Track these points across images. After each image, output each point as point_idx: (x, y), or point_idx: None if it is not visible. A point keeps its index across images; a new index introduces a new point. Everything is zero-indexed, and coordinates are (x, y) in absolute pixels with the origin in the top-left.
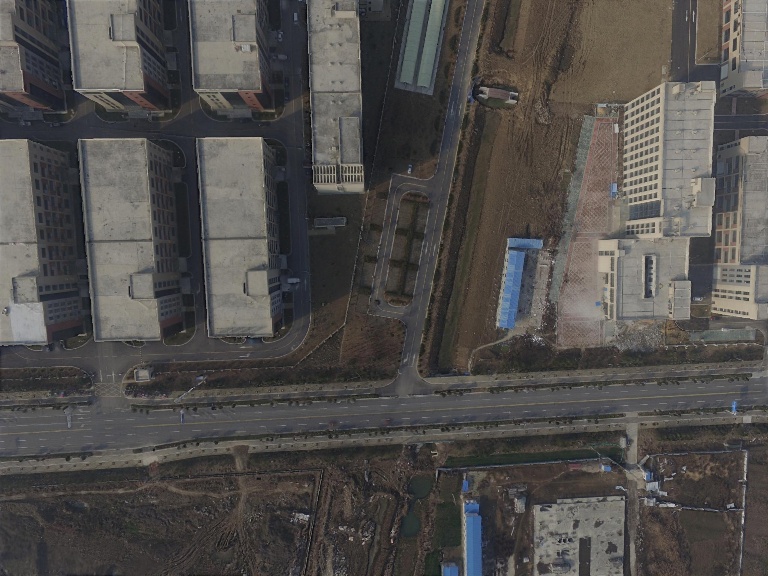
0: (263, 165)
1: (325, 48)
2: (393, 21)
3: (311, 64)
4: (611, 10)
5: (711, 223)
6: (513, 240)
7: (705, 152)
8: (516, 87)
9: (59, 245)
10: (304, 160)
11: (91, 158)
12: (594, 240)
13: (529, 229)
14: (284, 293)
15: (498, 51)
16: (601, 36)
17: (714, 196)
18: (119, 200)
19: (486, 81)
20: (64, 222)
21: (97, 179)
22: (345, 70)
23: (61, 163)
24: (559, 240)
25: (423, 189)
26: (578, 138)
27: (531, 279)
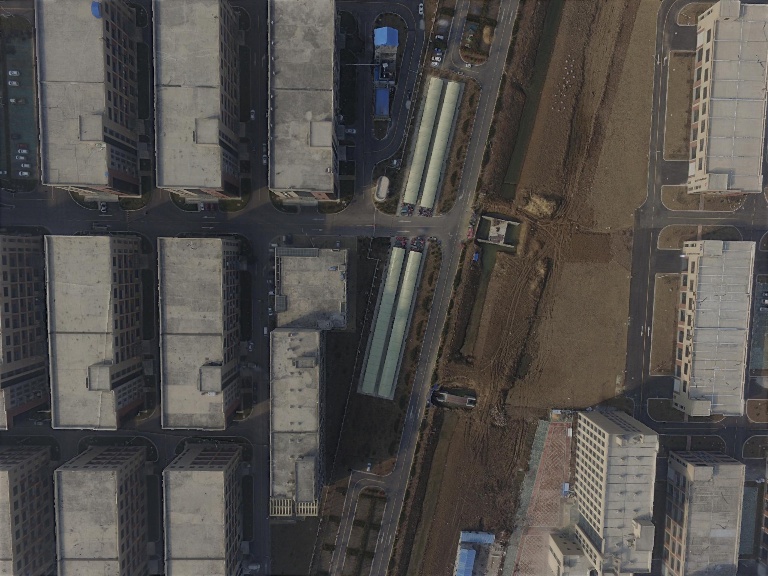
0: (224, 496)
1: (286, 393)
2: (358, 334)
3: (272, 407)
4: (568, 323)
5: (651, 562)
6: (466, 535)
7: (647, 495)
8: (474, 390)
9: (36, 543)
10: (269, 456)
11: (66, 486)
12: (545, 534)
13: (482, 521)
14: (245, 575)
15: (458, 357)
16: (558, 347)
17: (653, 542)
18: (90, 523)
19: (445, 385)
20: (42, 516)
21: (70, 504)
22: (304, 412)
23: (42, 463)
24: (511, 534)
25: (381, 484)
26: (532, 440)
27: (483, 568)
